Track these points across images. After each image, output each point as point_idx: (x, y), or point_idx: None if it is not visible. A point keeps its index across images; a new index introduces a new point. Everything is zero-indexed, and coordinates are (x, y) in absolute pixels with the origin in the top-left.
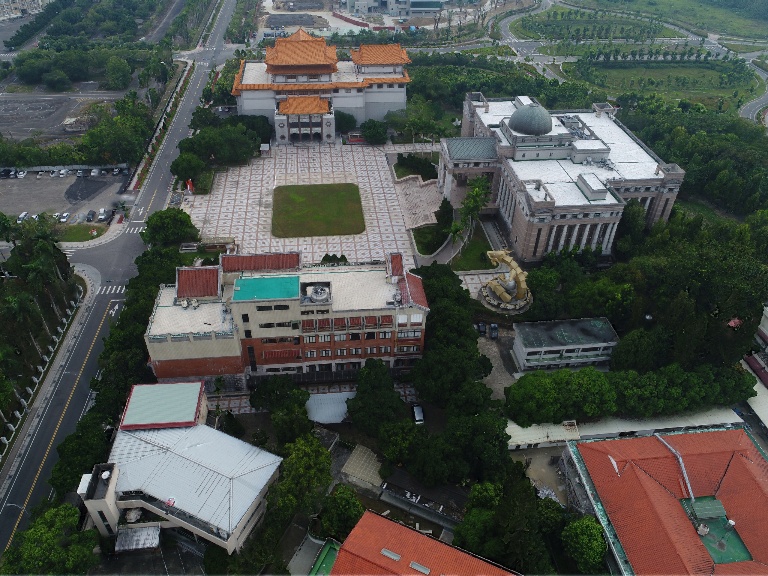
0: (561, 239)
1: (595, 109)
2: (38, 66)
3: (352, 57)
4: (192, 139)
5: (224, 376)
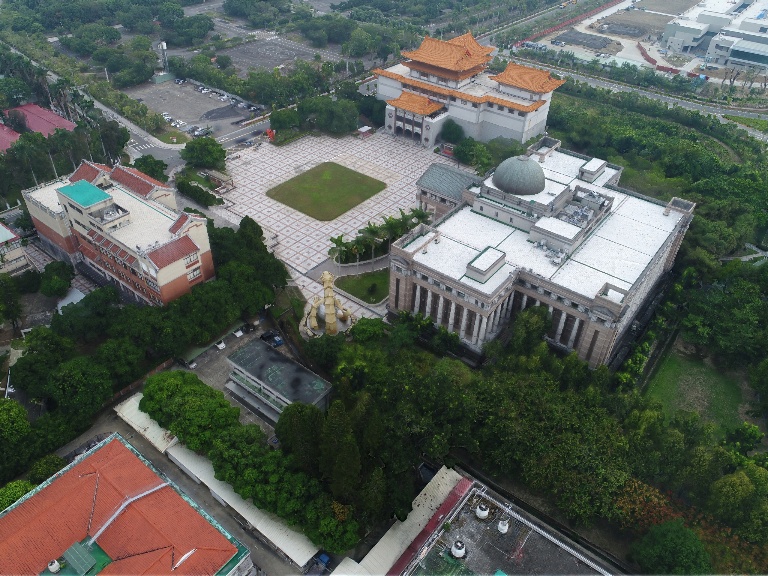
0: (427, 304)
1: (674, 205)
2: (317, 25)
3: (500, 73)
4: None
5: (63, 250)
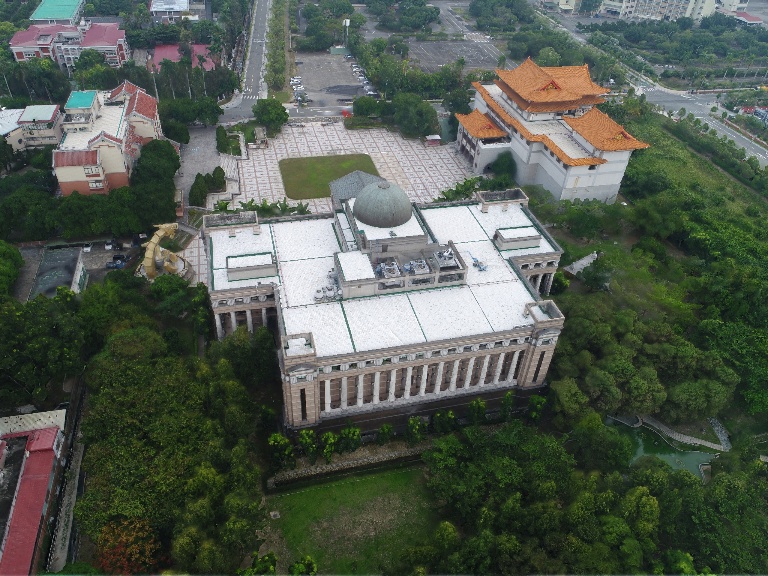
0: None
1: None
2: (527, 37)
3: None
4: None
5: None
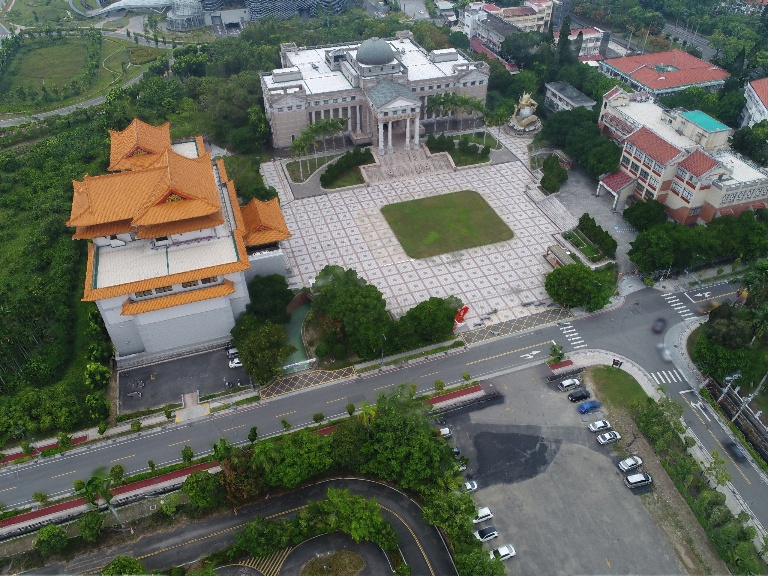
0: None
1: None
2: None
3: None
4: (367, 324)
5: None
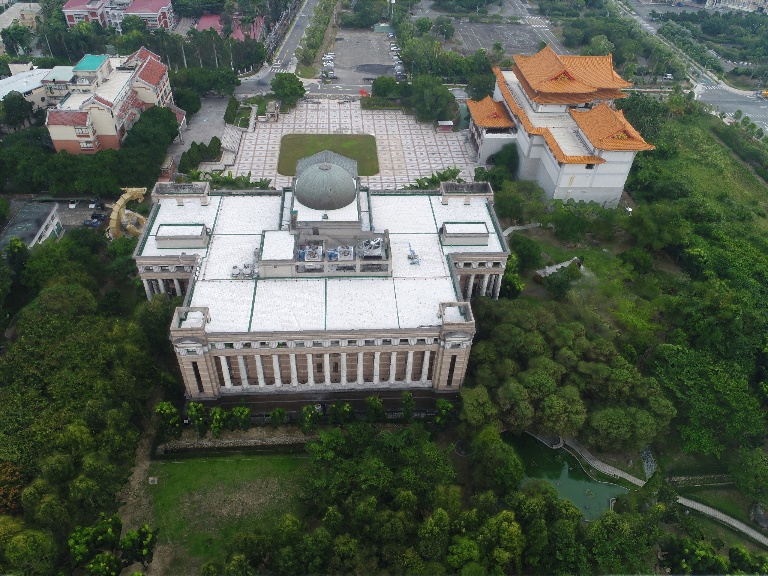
0: None
1: None
2: (587, 23)
3: None
4: None
5: None
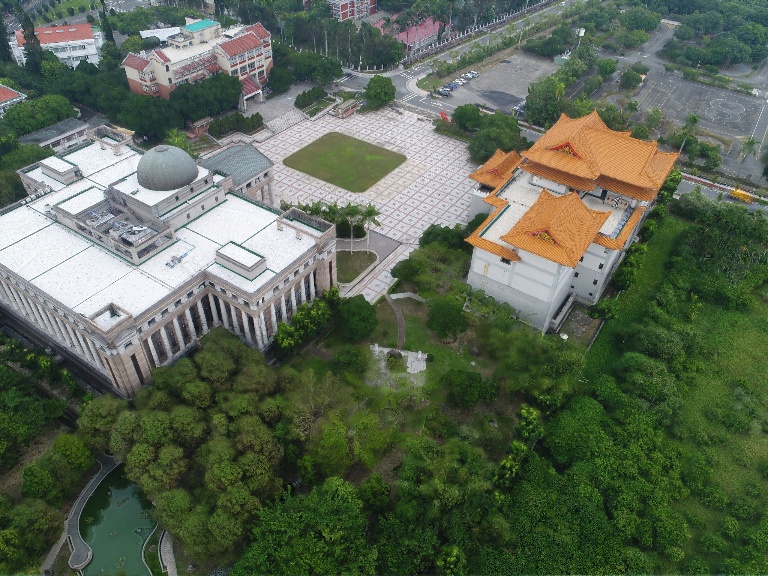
0: None
1: None
2: None
3: None
4: None
5: None
